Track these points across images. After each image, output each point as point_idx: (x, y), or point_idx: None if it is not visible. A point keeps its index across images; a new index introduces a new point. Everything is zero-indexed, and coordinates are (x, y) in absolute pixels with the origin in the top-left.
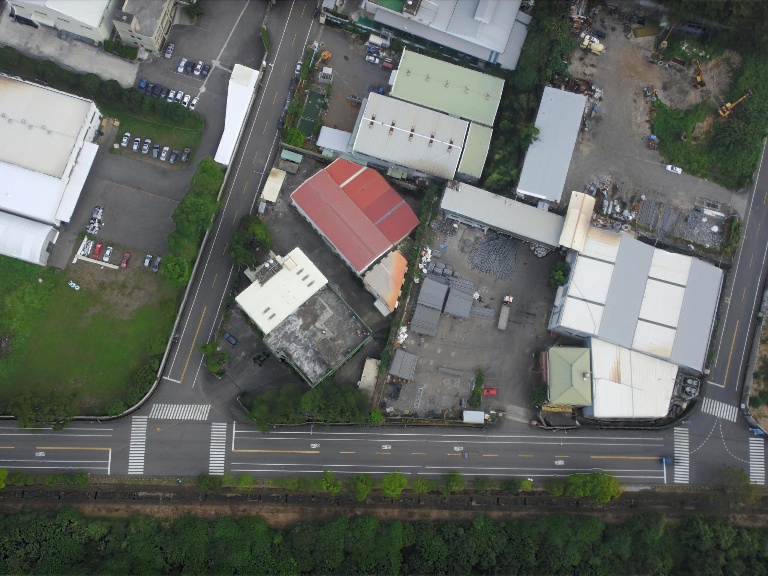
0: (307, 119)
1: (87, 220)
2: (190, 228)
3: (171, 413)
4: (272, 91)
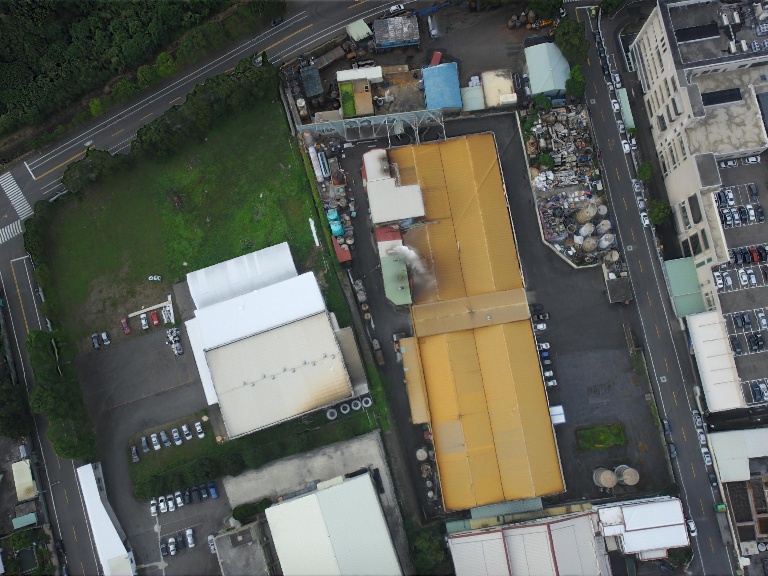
0: (31, 570)
1: (183, 337)
2: (36, 379)
3: (3, 234)
4: (90, 575)
